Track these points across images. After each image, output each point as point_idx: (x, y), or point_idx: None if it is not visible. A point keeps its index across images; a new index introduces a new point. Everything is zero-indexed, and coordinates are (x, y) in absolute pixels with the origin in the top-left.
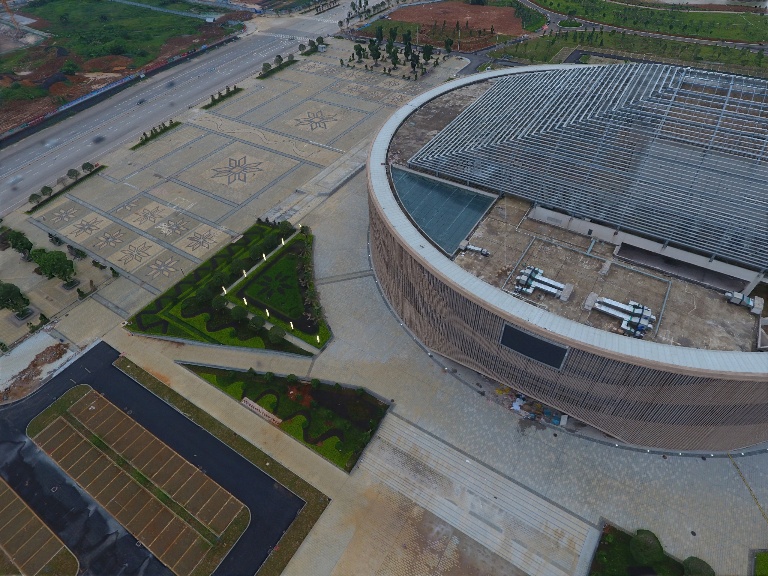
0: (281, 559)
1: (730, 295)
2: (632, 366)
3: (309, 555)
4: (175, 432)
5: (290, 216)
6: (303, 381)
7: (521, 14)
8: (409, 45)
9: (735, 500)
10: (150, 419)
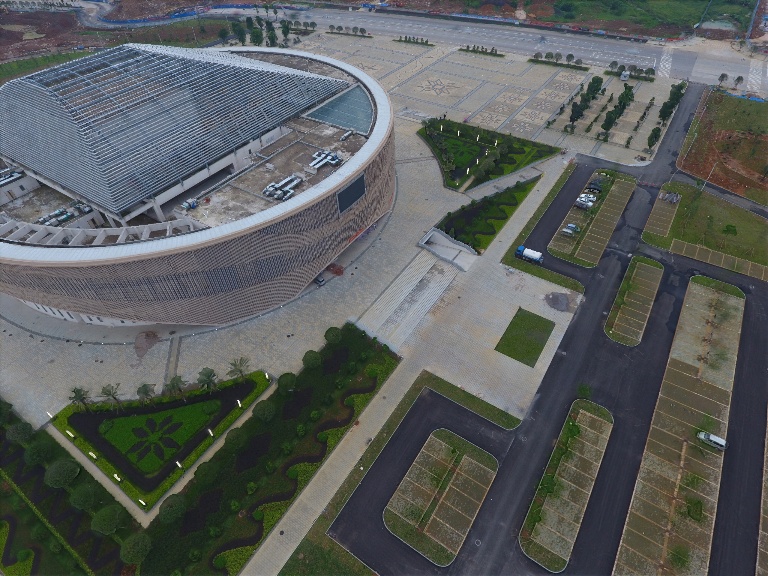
0: None
1: None
2: None
3: None
4: None
5: None
6: None
7: None
8: (623, 106)
9: None
10: None
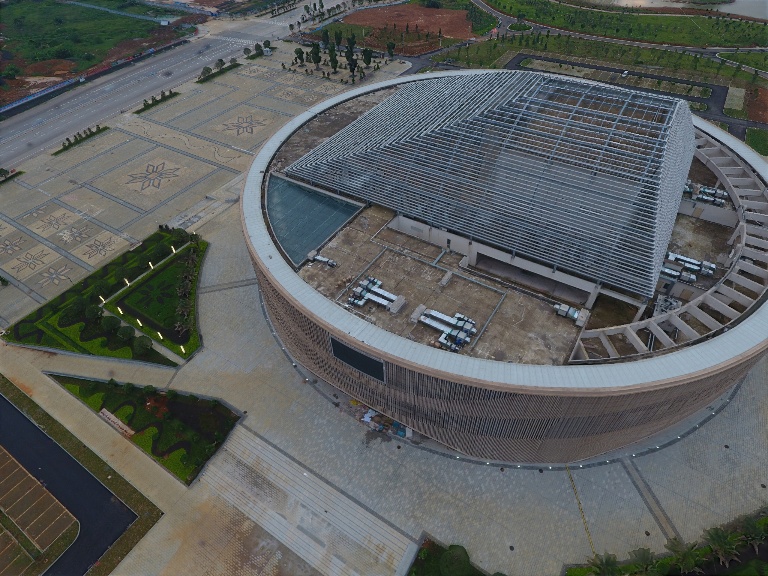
0: (99, 575)
1: (558, 307)
2: (440, 380)
3: (128, 571)
4: (25, 444)
5: (193, 223)
6: (162, 392)
7: (473, 17)
8: (350, 49)
9: (562, 514)
10: (3, 431)
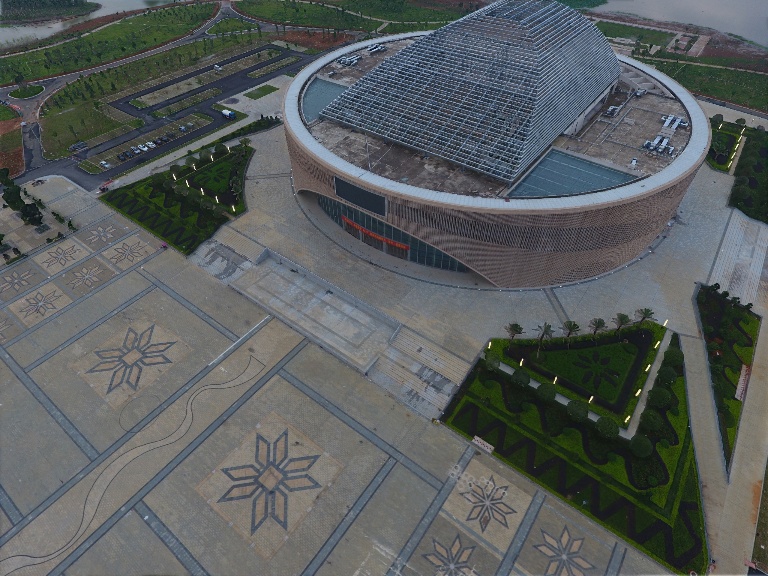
0: None
1: None
2: None
3: None
4: None
5: (436, 374)
6: None
7: None
8: None
9: None
10: None
